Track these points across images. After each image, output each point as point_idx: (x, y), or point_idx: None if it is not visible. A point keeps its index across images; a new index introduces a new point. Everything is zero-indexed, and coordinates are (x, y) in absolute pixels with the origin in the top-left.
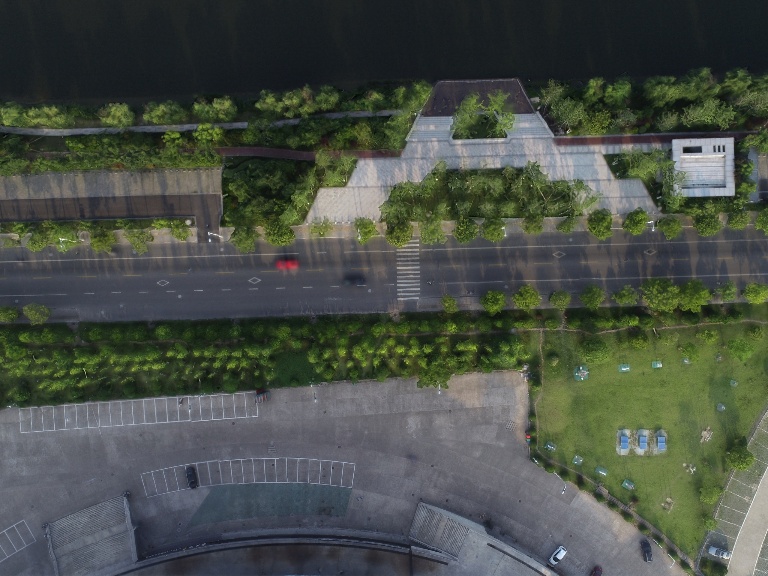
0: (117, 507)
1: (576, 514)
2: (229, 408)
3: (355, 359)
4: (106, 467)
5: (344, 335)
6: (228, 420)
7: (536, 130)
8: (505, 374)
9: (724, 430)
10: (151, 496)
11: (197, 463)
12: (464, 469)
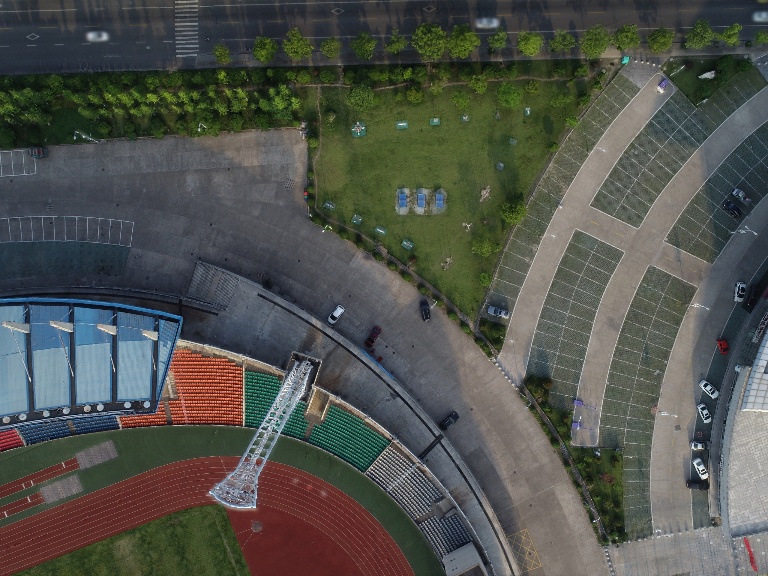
0: None
1: (355, 274)
2: (7, 165)
3: (133, 115)
4: None
5: (115, 84)
6: (6, 177)
7: None
8: (284, 132)
9: (503, 189)
10: None
11: None
12: (243, 228)
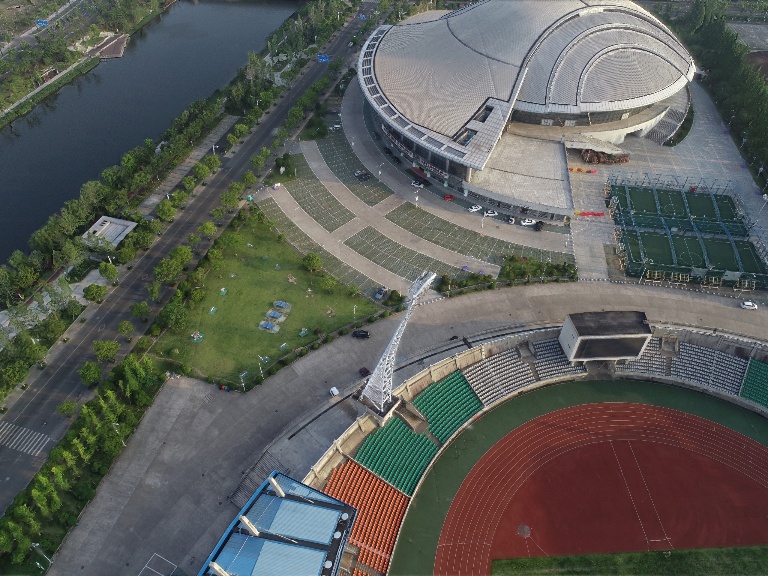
0: None
1: (309, 373)
2: None
3: (55, 514)
4: None
5: None
6: None
7: (4, 317)
8: (163, 390)
9: (294, 270)
10: None
11: None
12: (222, 448)
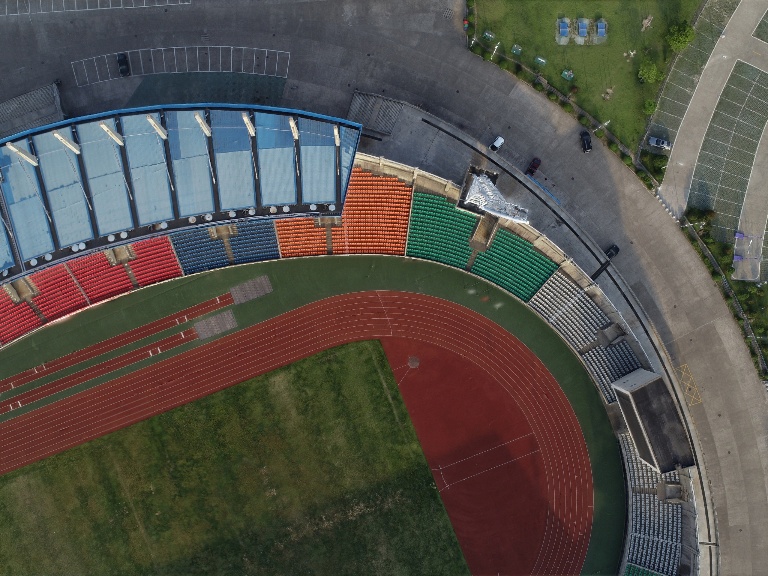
0: (47, 93)
1: (515, 105)
2: None
3: None
4: (36, 55)
5: None
6: (161, 7)
7: None
8: None
9: (665, 18)
10: (82, 86)
11: (129, 51)
12: (401, 58)
